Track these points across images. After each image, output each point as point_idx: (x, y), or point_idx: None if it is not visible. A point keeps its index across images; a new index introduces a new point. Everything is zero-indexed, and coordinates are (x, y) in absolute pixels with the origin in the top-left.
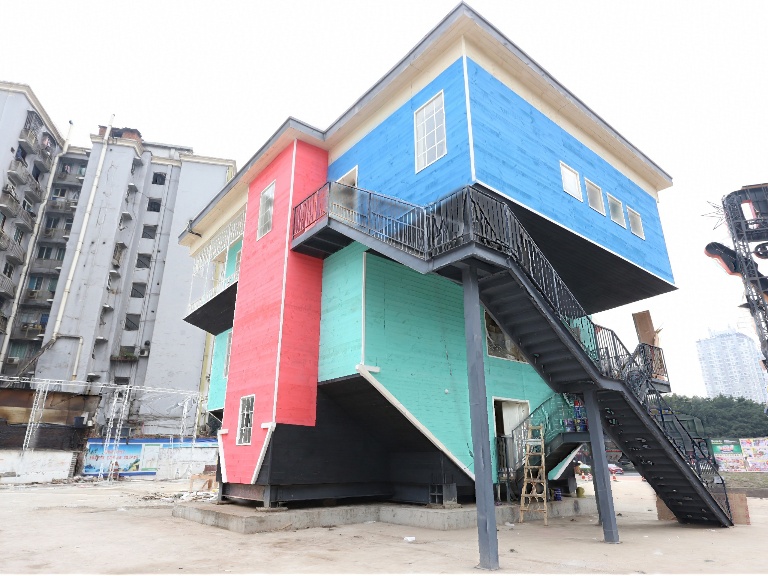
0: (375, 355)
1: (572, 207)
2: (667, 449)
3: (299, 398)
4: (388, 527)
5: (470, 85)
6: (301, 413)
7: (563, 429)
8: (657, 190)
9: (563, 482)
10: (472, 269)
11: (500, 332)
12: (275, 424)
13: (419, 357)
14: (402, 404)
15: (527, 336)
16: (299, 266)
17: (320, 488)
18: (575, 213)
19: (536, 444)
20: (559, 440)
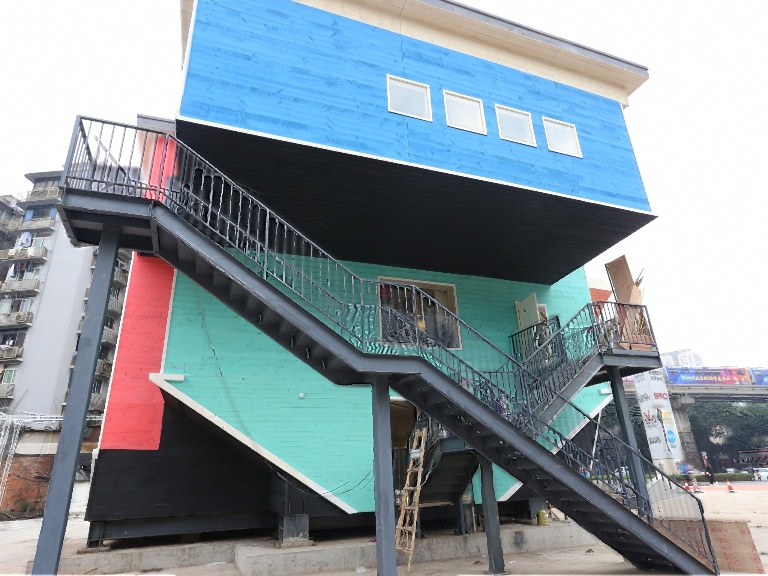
0: (183, 360)
1: (405, 130)
2: (530, 457)
3: (137, 418)
4: (209, 572)
5: (202, 6)
6: (139, 436)
7: (442, 434)
8: (630, 90)
9: (524, 504)
10: (108, 228)
11: (433, 314)
12: (98, 450)
13: (258, 357)
14: (220, 417)
15: (261, 310)
16: (149, 271)
17: (167, 522)
18: (411, 137)
19: (416, 456)
20: (439, 449)
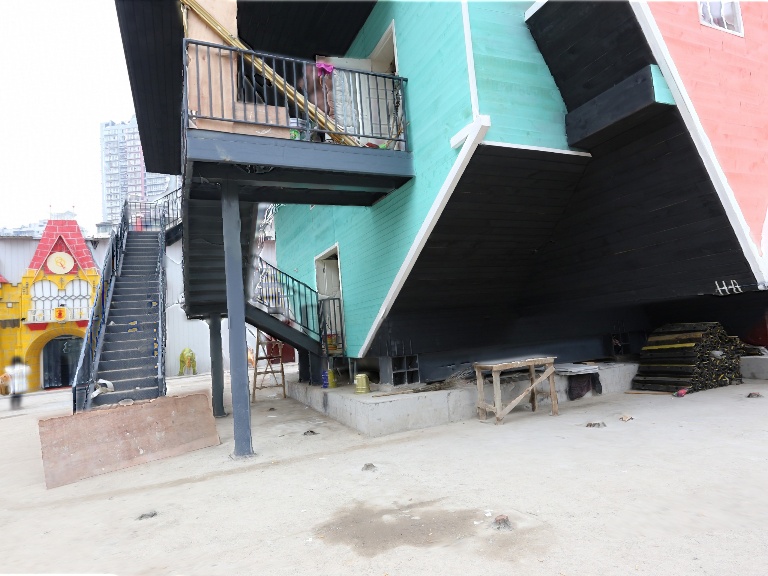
0: None
1: None
2: None
3: None
4: None
5: None
6: None
7: None
8: None
9: None
10: None
11: None
12: None
13: None
14: None
15: None
16: None
17: None
18: None
19: None
20: None
